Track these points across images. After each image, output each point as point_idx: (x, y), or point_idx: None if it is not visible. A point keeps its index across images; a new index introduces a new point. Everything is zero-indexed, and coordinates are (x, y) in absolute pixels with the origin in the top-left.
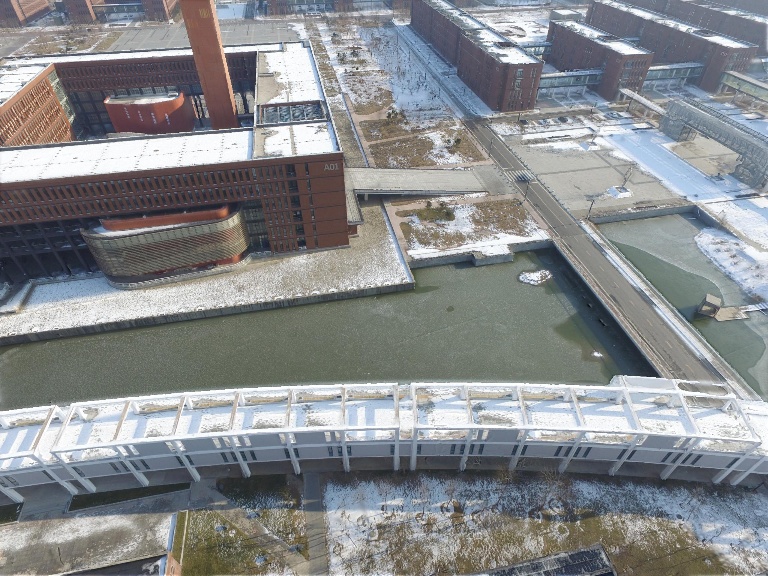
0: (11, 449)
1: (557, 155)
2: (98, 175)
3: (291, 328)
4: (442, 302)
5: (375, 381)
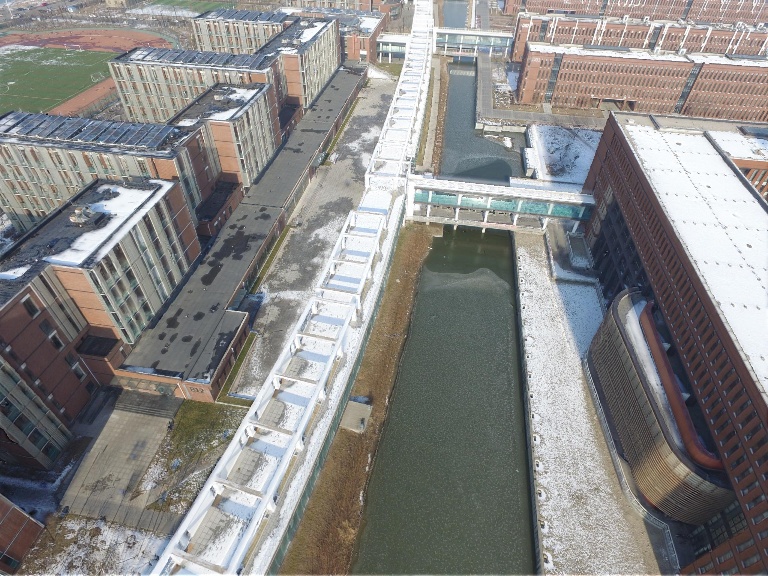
0: (345, 282)
1: None
2: (693, 267)
3: (484, 571)
4: None
5: None
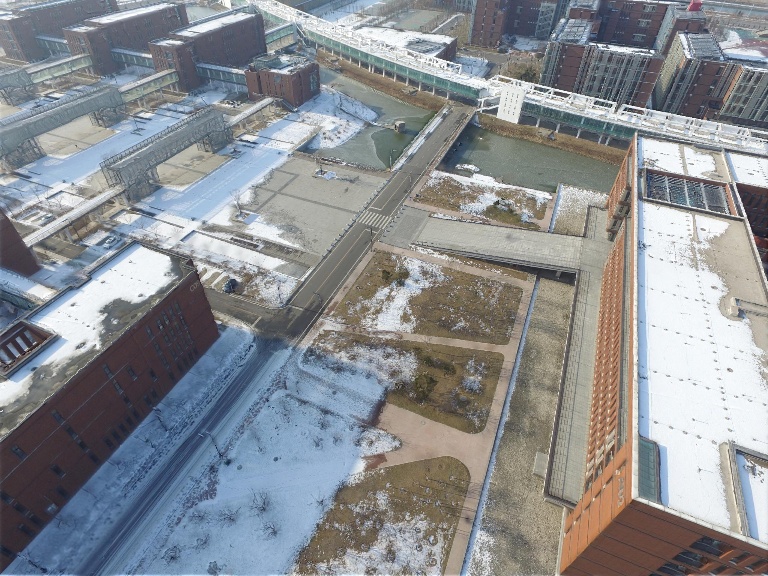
0: None
1: (298, 223)
2: None
3: None
4: (543, 178)
5: (606, 165)
